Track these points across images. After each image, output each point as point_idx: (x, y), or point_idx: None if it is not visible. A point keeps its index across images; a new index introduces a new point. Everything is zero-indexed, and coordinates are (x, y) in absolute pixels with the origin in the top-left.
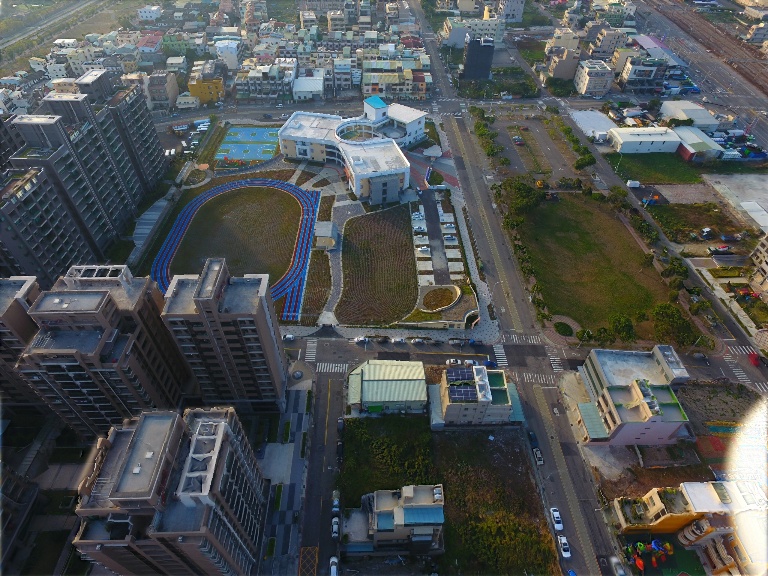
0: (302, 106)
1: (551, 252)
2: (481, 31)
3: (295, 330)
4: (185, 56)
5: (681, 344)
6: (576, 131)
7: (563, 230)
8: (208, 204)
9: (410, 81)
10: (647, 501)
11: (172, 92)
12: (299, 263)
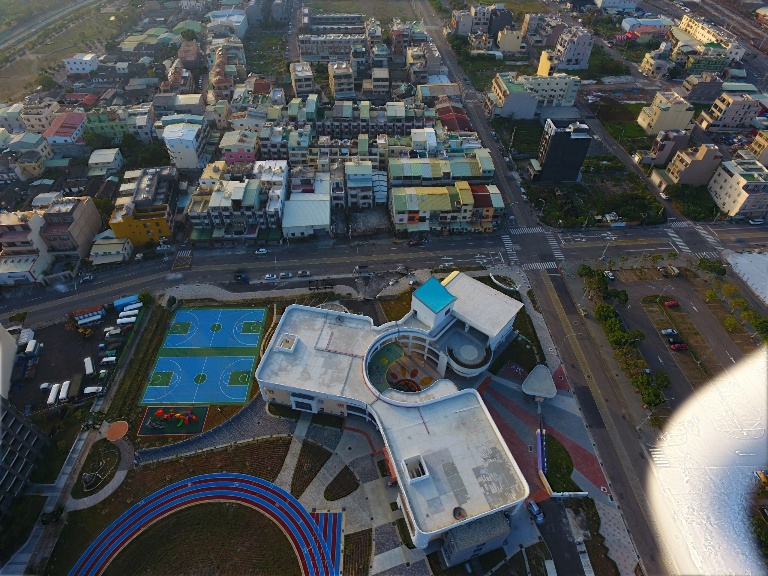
0: (298, 250)
1: None
2: (545, 92)
3: None
4: (120, 145)
5: None
6: (758, 307)
7: None
8: (110, 574)
9: (469, 206)
10: None
11: (86, 230)
12: None
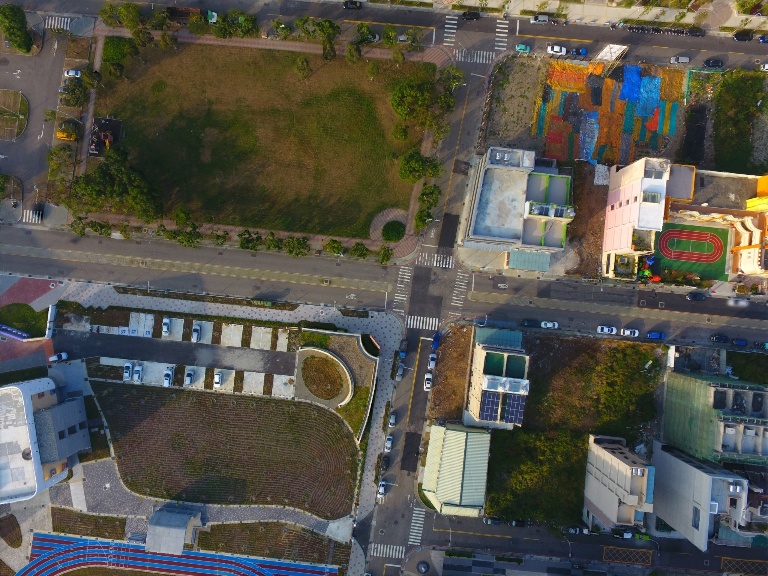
0: None
1: (248, 188)
2: None
3: (354, 572)
4: None
5: (450, 109)
6: None
7: (196, 147)
8: None
9: None
10: (626, 255)
11: None
12: (226, 569)
